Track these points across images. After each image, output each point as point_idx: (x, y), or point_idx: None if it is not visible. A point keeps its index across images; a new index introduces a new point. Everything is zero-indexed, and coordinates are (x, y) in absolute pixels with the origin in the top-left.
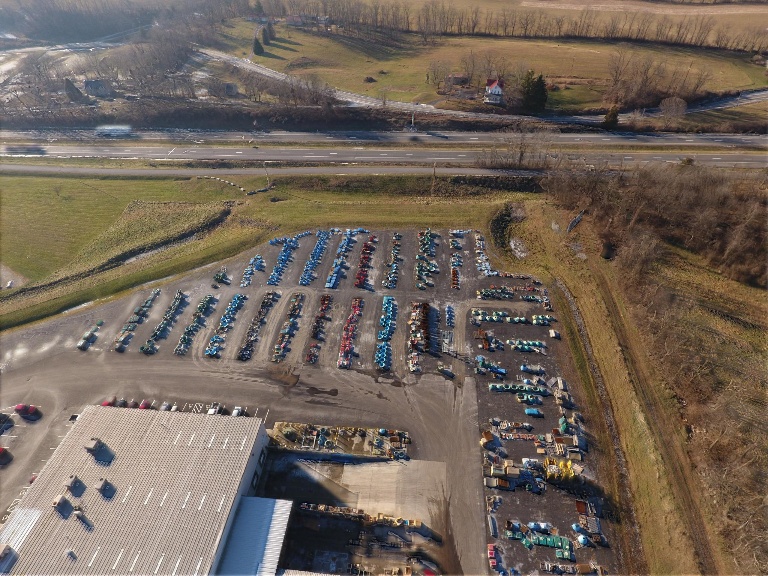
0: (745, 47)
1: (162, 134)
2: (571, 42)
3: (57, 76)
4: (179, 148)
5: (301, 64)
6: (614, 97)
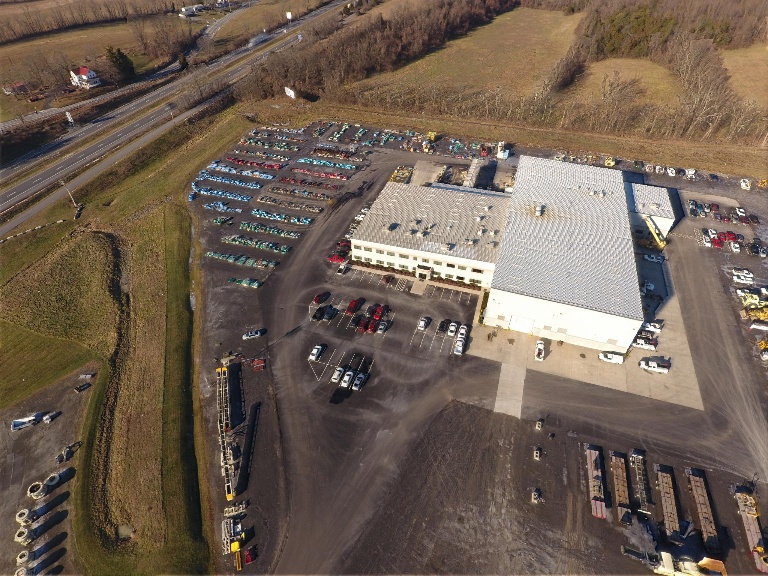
0: (153, 12)
1: None
2: (40, 39)
3: None
4: None
5: None
6: (163, 52)
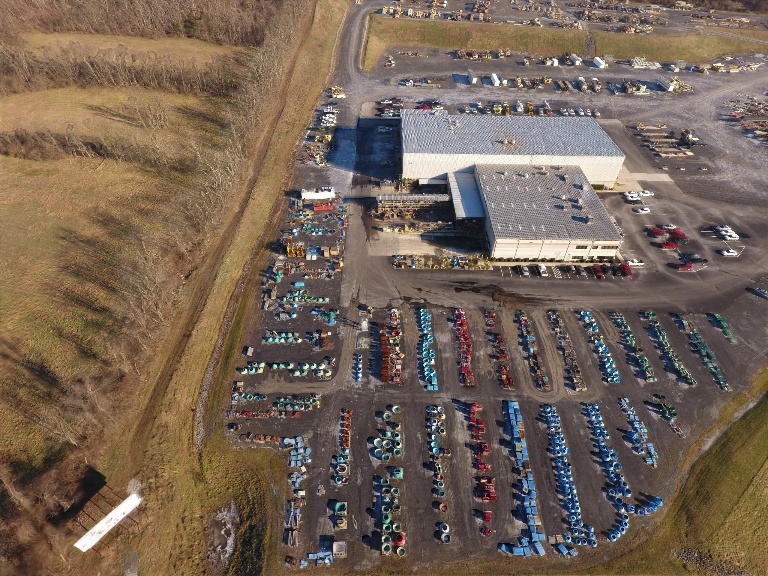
0: None
1: None
2: None
3: None
4: None
5: None
6: None
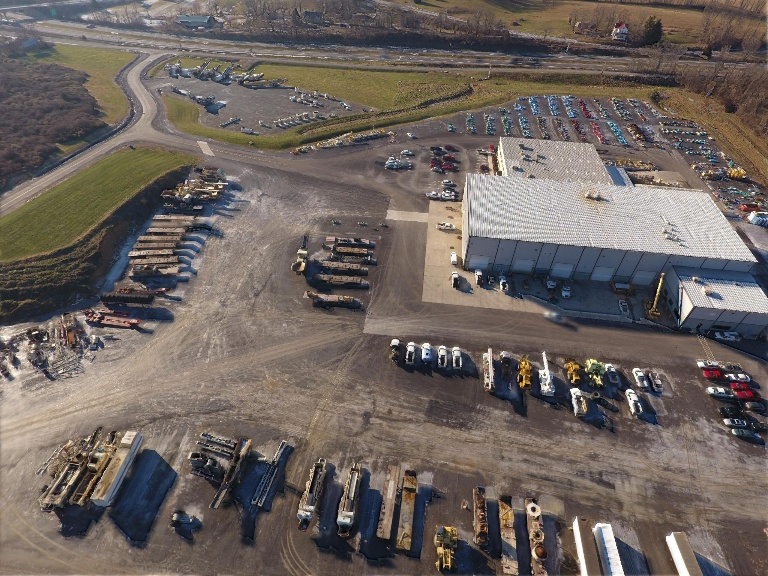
0: None
1: (382, 49)
2: None
3: (268, 10)
4: (404, 56)
5: (455, 12)
6: (707, 39)
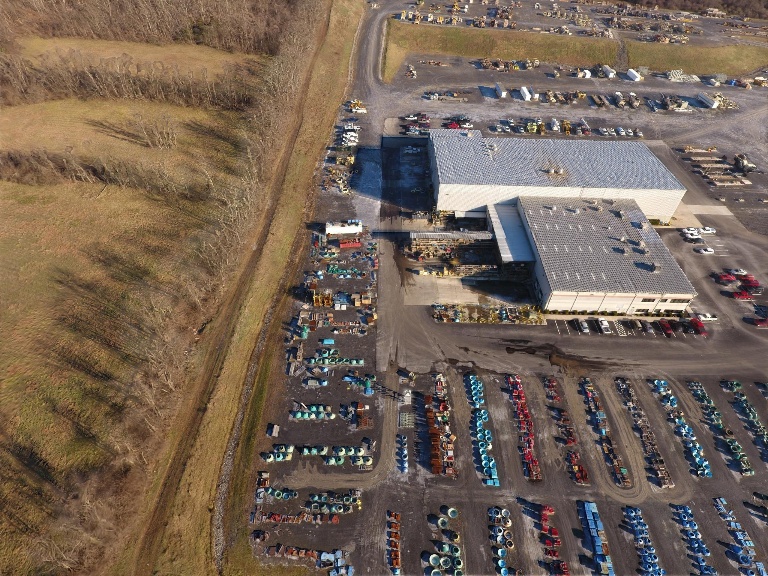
0: None
1: None
2: None
3: None
4: None
5: None
6: None
